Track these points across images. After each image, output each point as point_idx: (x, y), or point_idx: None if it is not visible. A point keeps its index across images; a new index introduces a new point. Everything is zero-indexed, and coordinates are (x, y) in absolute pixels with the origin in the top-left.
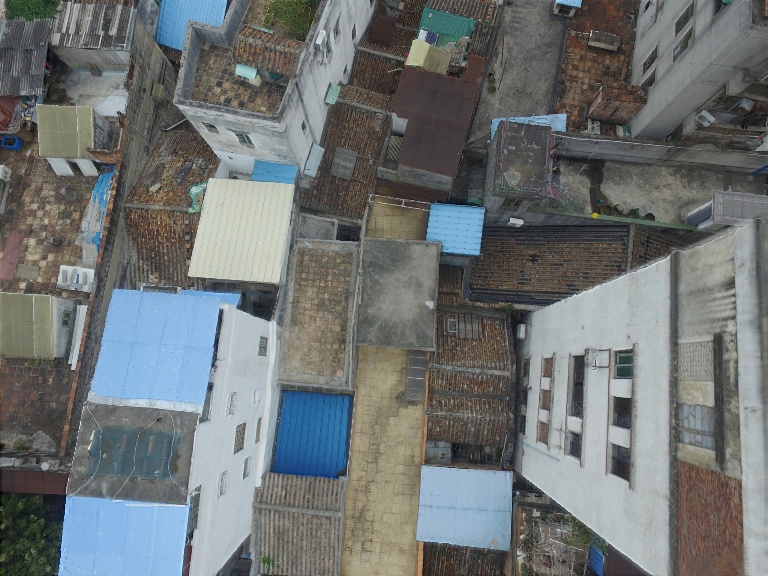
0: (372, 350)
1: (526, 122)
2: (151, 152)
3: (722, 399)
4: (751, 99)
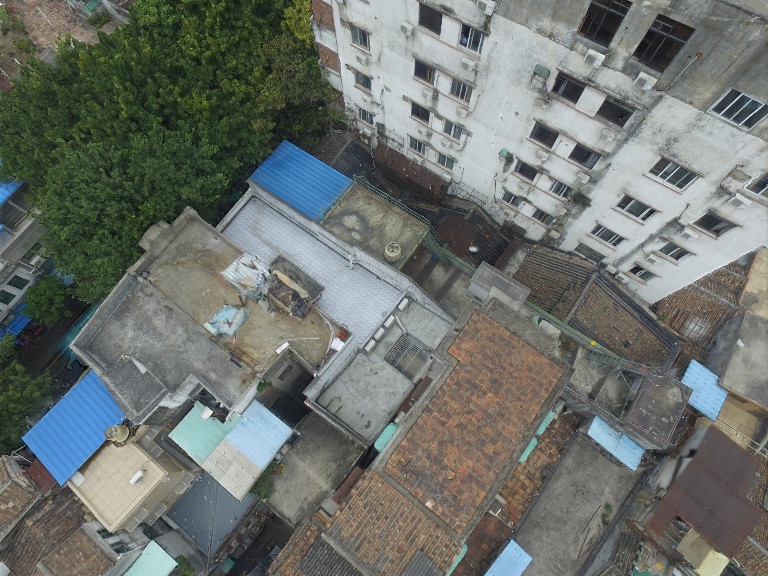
0: None
1: (615, 448)
2: None
3: None
4: None
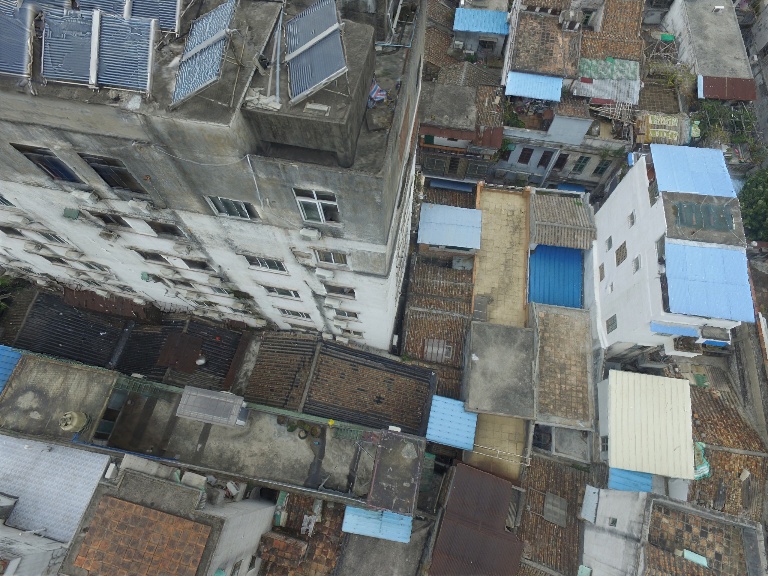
0: None
1: (379, 530)
2: (762, 527)
3: (405, 177)
4: (207, 483)
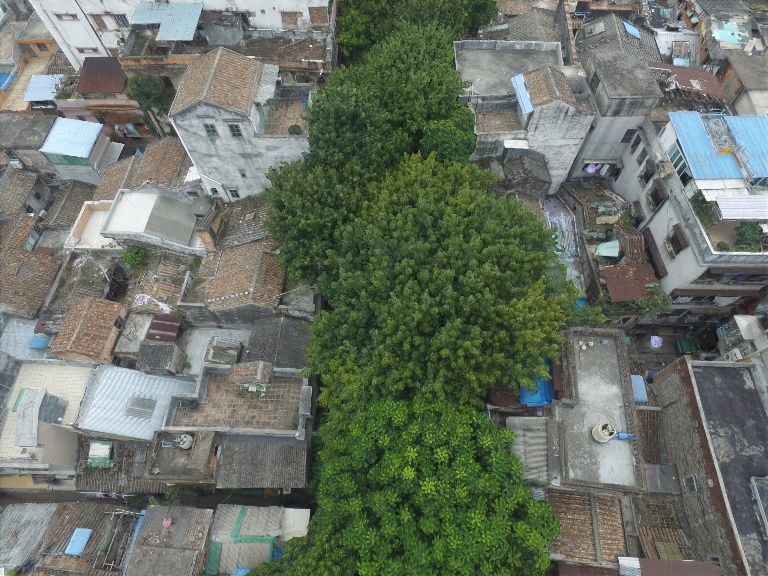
0: (36, 59)
1: None
2: None
3: None
4: None
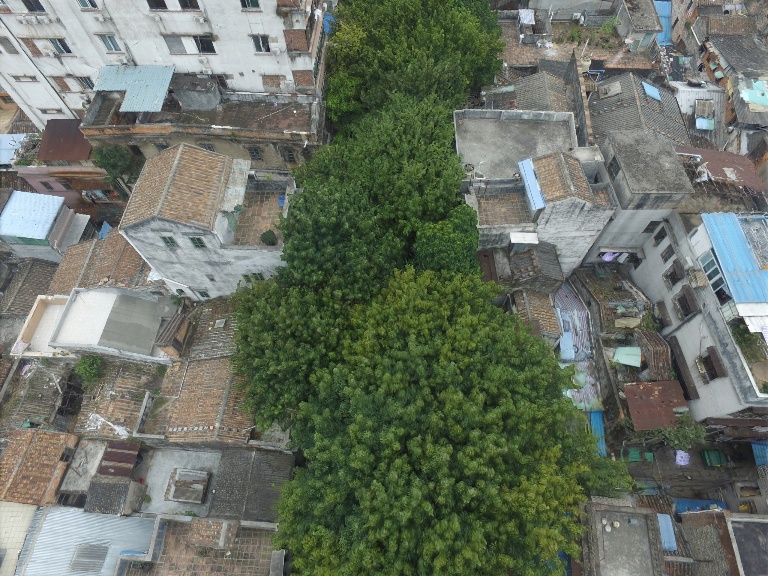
0: (1, 112)
1: None
2: None
3: None
4: None
